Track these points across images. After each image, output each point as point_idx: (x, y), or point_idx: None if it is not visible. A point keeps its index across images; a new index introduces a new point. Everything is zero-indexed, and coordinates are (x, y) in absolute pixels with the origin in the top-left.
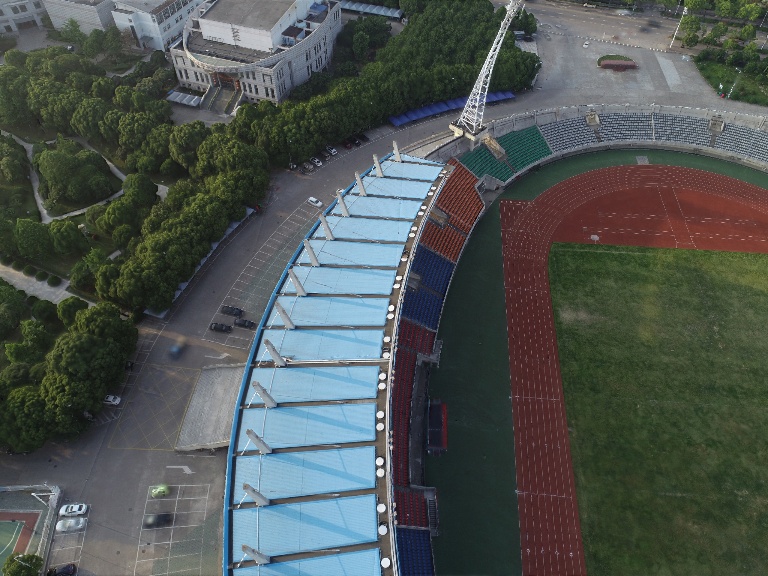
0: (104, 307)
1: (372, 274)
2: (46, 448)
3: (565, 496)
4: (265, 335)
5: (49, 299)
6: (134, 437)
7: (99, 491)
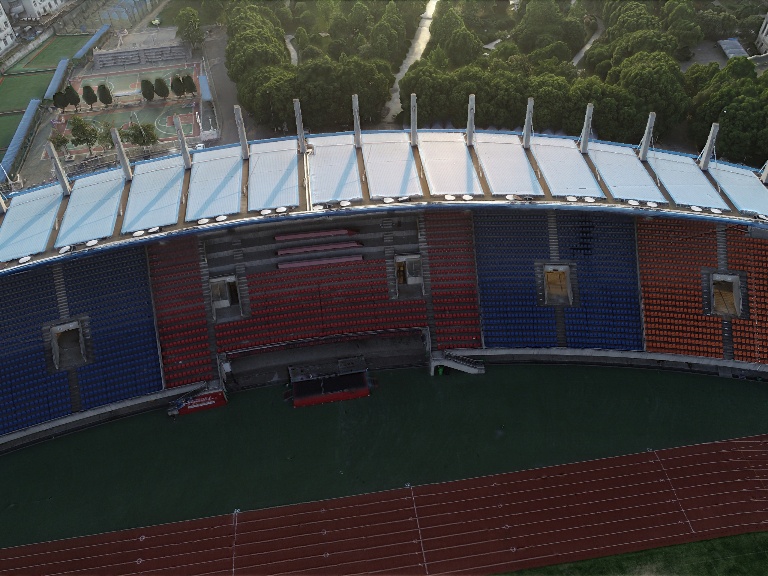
0: (367, 65)
1: (468, 178)
2: None
3: None
4: (345, 136)
5: (402, 76)
6: None
7: None
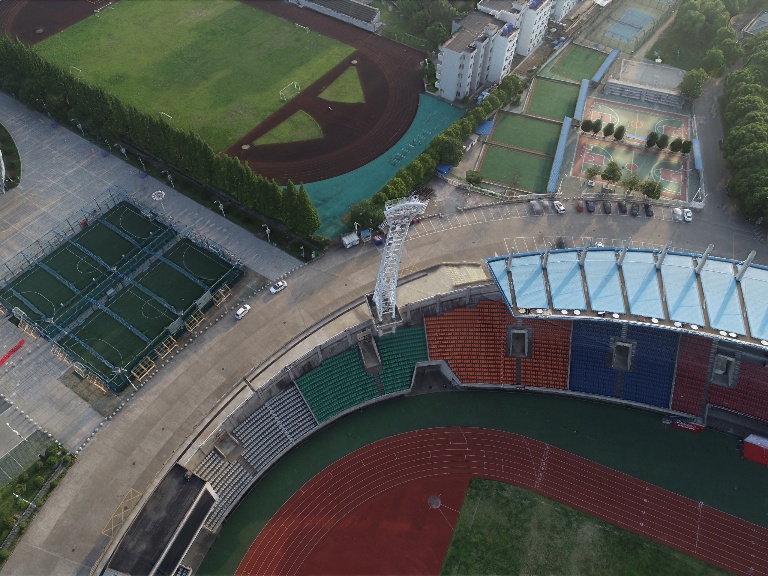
0: None
1: None
2: (732, 202)
3: (697, 547)
4: None
5: None
6: (743, 246)
7: (701, 228)
